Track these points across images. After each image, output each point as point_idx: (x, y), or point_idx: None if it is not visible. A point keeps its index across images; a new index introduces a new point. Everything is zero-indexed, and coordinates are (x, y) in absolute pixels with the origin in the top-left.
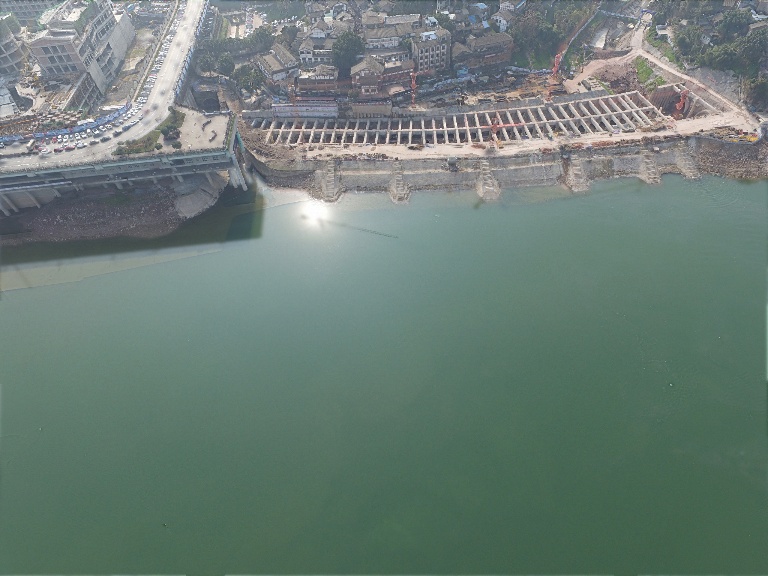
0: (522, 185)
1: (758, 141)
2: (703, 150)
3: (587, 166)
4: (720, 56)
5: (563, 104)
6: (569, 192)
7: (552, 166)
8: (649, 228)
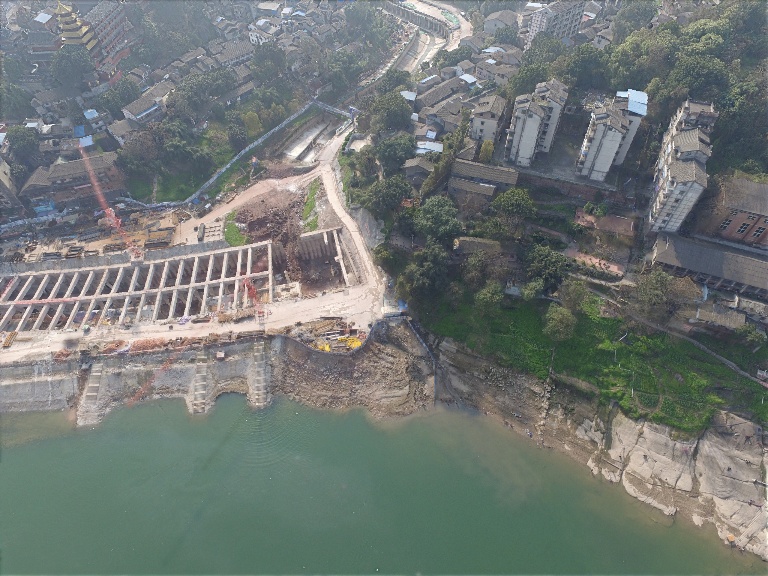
0: (16, 409)
1: (359, 349)
2: (287, 357)
3: (114, 381)
4: (365, 202)
5: (157, 262)
6: (71, 426)
7: (62, 381)
8: (128, 511)
